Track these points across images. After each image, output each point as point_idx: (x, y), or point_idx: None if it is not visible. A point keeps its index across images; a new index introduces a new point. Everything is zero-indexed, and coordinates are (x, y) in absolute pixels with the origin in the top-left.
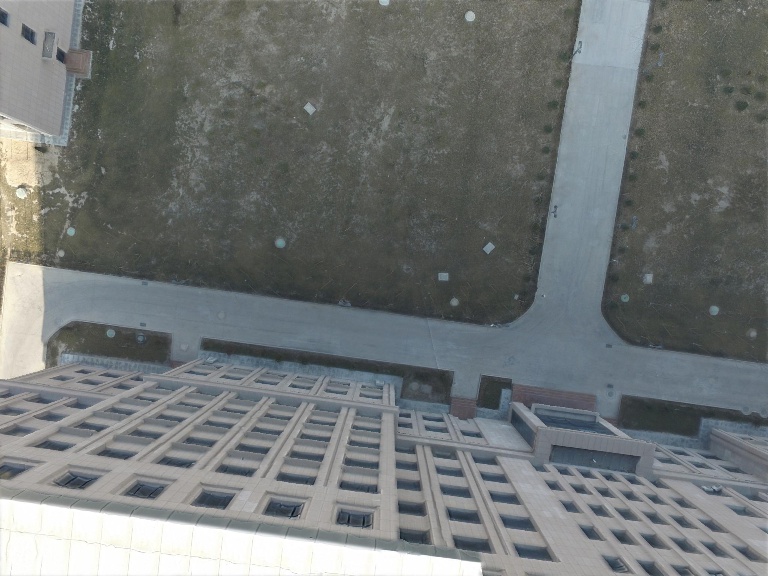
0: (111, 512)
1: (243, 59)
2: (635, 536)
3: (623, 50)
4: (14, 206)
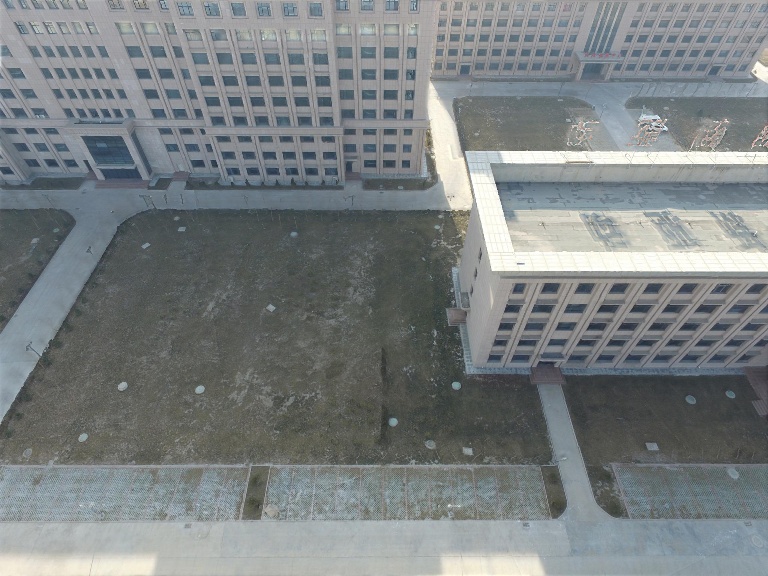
0: None
1: (326, 335)
2: (84, 53)
3: None
4: None
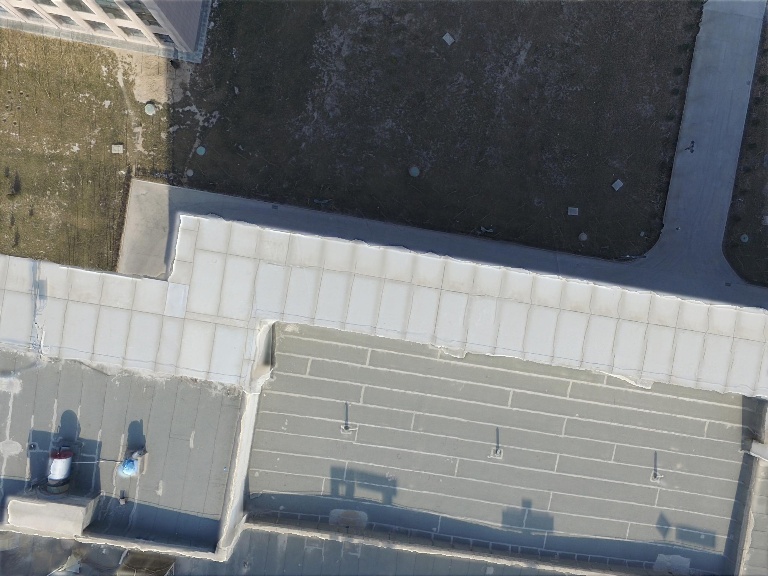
0: (566, 280)
1: None
2: None
3: None
4: (141, 122)
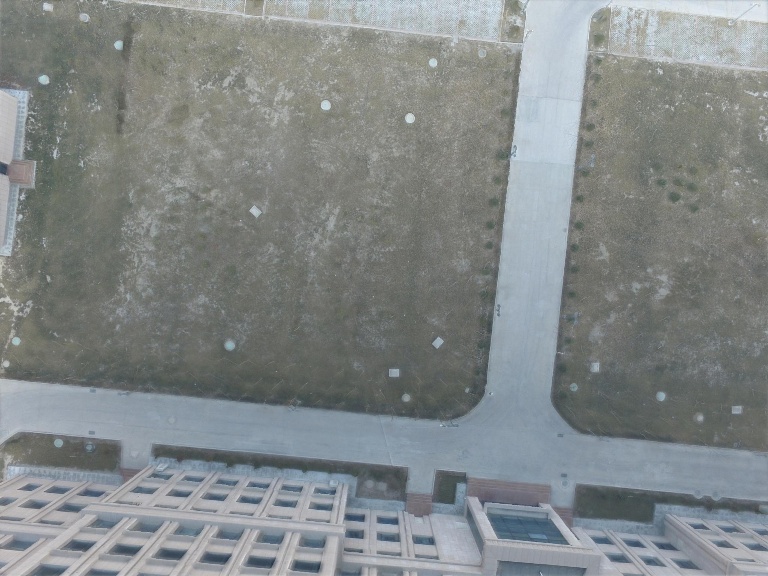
0: None
1: (188, 165)
2: None
3: (559, 147)
4: None
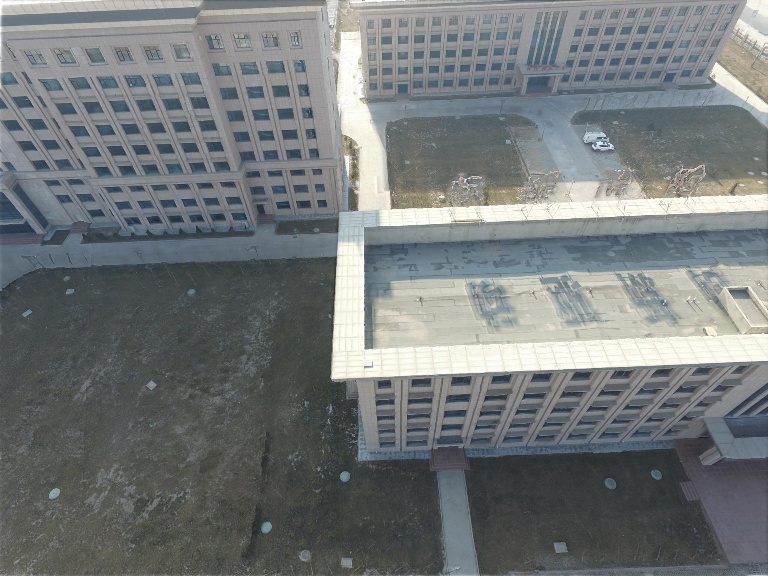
0: (71, 3)
1: (208, 416)
2: None
3: None
4: None
